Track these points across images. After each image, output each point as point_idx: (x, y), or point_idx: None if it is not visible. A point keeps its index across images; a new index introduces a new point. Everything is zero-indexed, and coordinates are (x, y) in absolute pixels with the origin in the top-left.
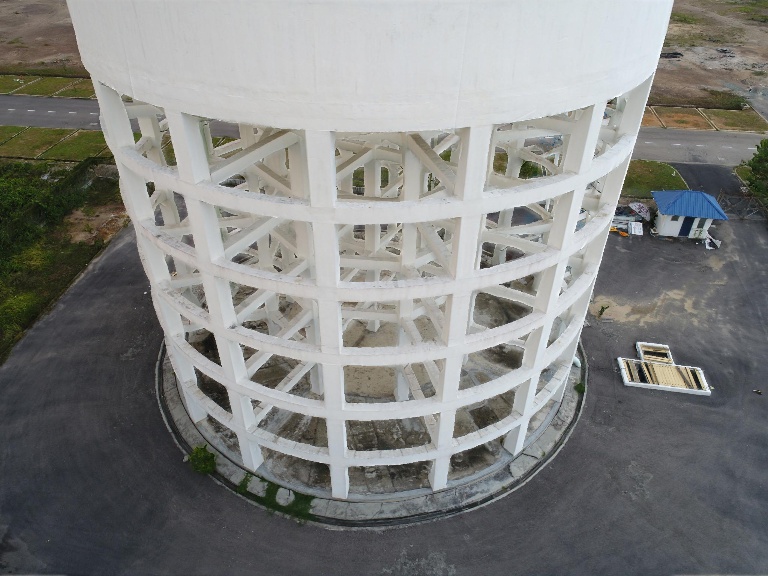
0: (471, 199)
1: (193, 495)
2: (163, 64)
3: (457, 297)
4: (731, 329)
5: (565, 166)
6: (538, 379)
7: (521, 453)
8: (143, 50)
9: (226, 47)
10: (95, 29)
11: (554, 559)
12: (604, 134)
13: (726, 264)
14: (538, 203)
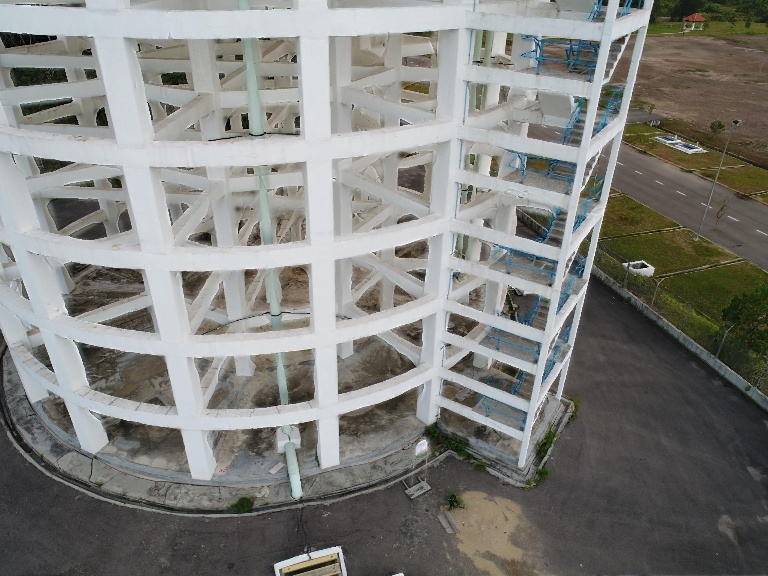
0: None
1: None
2: None
3: None
4: None
5: None
6: (56, 344)
7: (93, 457)
8: None
9: None
10: None
11: None
12: None
13: None
14: (733, 381)
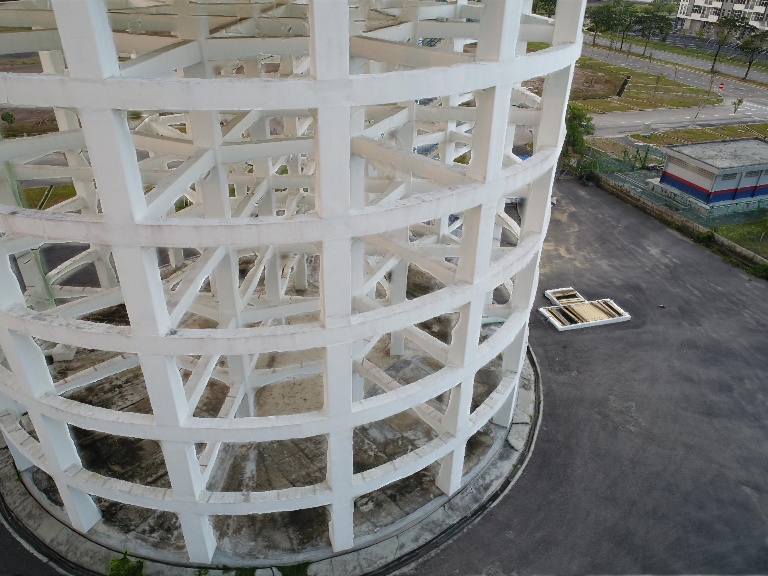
0: (506, 59)
1: None
2: None
3: (485, 209)
4: (608, 263)
5: (556, 38)
6: None
7: (511, 423)
8: None
9: None
10: None
11: (606, 519)
12: (541, 32)
13: (569, 215)
14: None
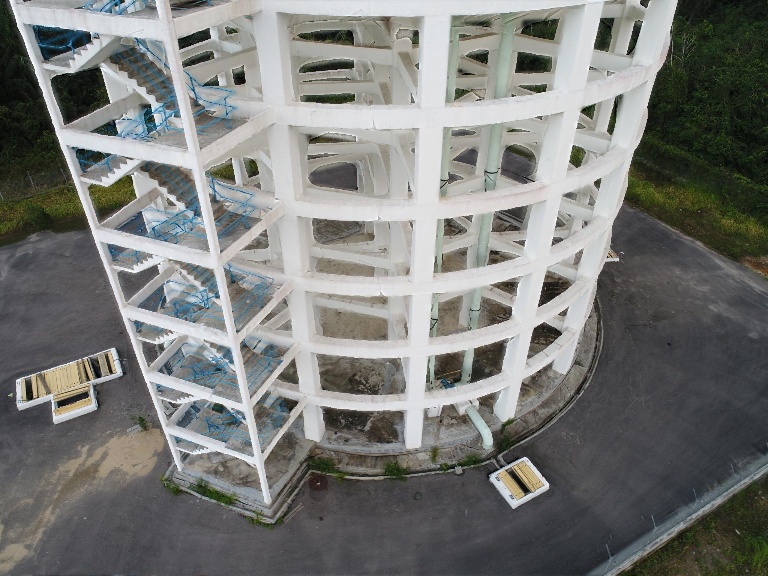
0: None
1: None
2: None
3: None
4: None
5: None
6: None
7: None
8: None
9: None
10: None
11: None
12: None
13: None
14: None
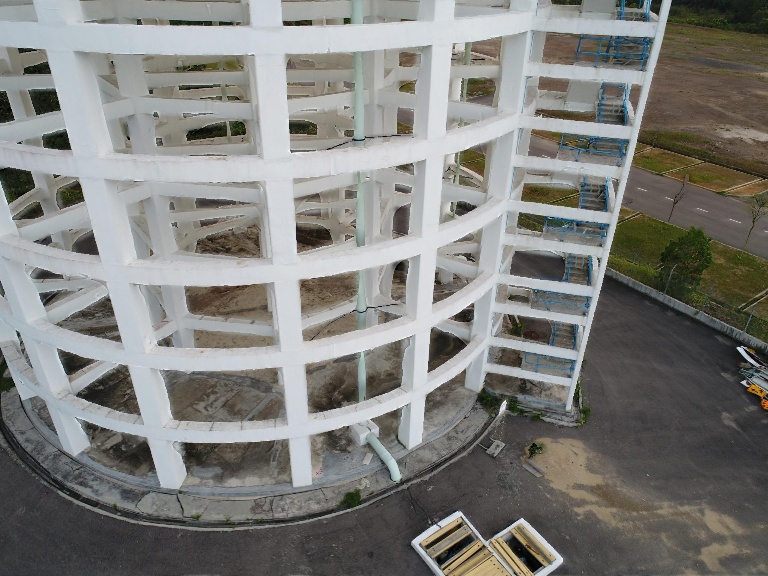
0: None
1: None
2: None
3: None
4: None
5: None
6: (150, 379)
7: (176, 493)
8: None
9: None
10: None
11: None
12: None
13: None
14: (682, 310)
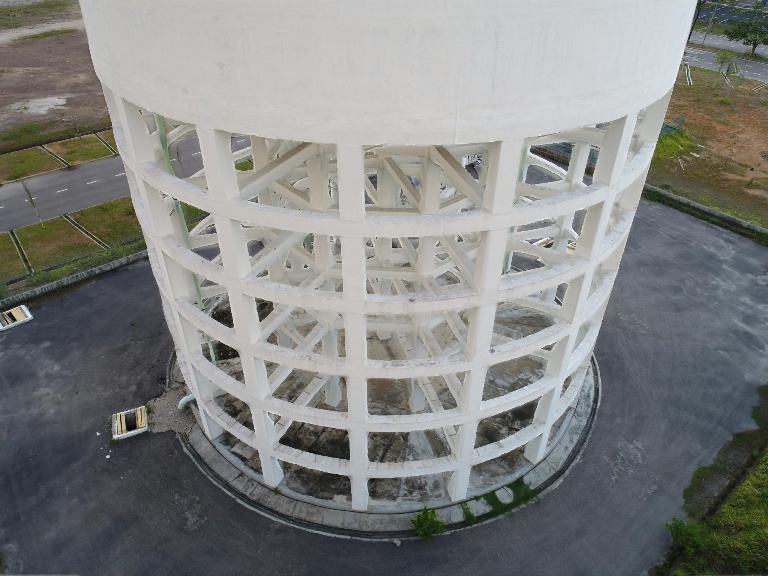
0: None
1: (444, 559)
2: (518, 92)
3: None
4: None
5: None
6: None
7: None
8: (493, 84)
9: (594, 56)
10: (396, 80)
11: (662, 393)
12: None
13: None
14: None
